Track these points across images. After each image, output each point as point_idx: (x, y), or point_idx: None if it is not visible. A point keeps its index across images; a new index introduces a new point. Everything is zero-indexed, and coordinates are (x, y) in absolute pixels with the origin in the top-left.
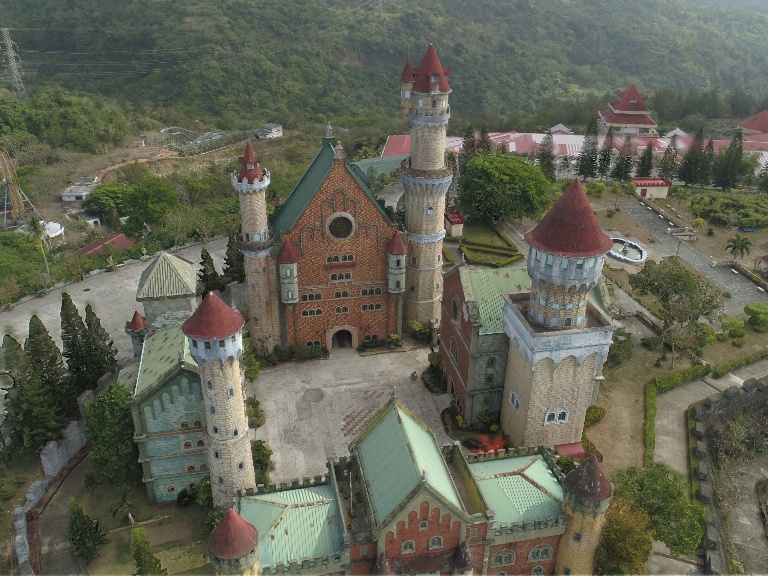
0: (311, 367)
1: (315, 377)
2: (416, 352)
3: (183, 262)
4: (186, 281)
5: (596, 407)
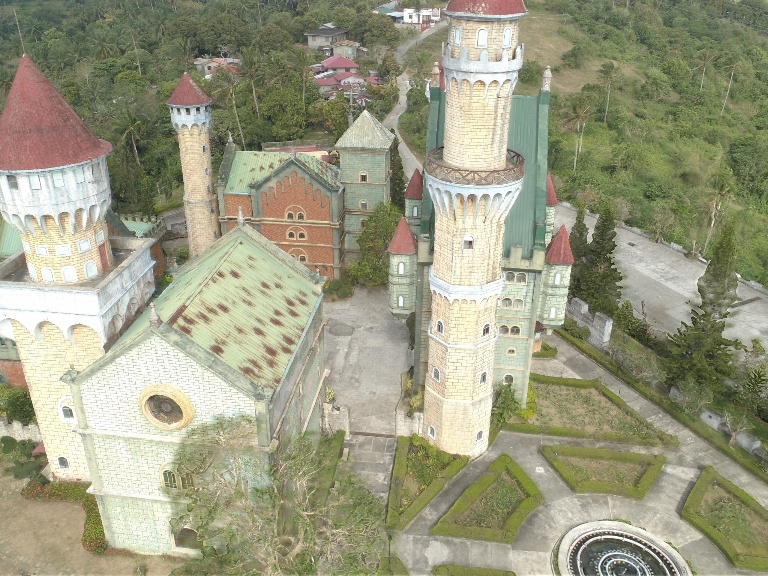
0: (398, 335)
1: (376, 335)
2: (391, 419)
3: (378, 132)
4: (347, 137)
5: (102, 534)
